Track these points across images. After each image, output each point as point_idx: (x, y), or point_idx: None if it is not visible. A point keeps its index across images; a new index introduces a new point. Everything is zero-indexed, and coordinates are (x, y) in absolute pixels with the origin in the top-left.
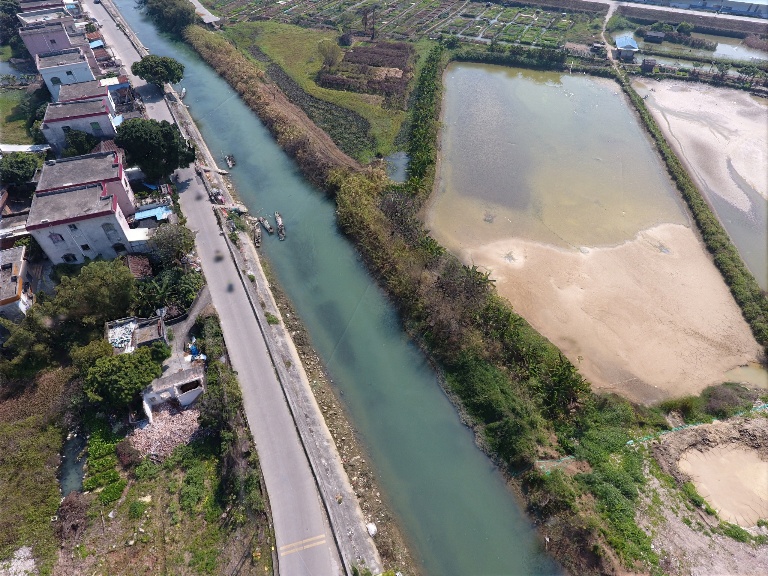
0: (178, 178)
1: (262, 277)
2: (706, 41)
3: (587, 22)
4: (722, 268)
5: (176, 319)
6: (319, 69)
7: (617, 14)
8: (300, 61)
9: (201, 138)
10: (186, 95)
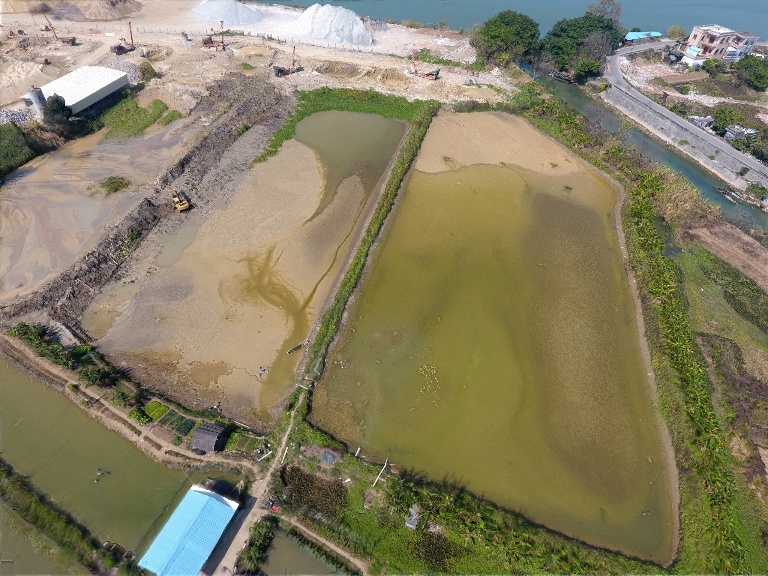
0: None
1: (707, 164)
2: None
3: None
4: None
5: None
6: None
7: None
8: None
9: None
10: None
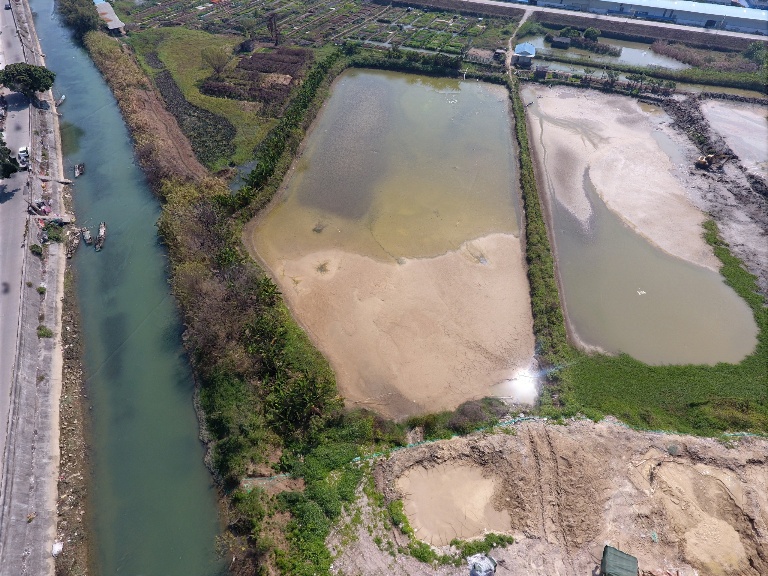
0: (6, 188)
1: (58, 289)
2: (610, 47)
3: (501, 27)
4: (530, 279)
5: None
6: (209, 76)
7: (531, 19)
8: (193, 68)
9: (59, 146)
10: (64, 102)
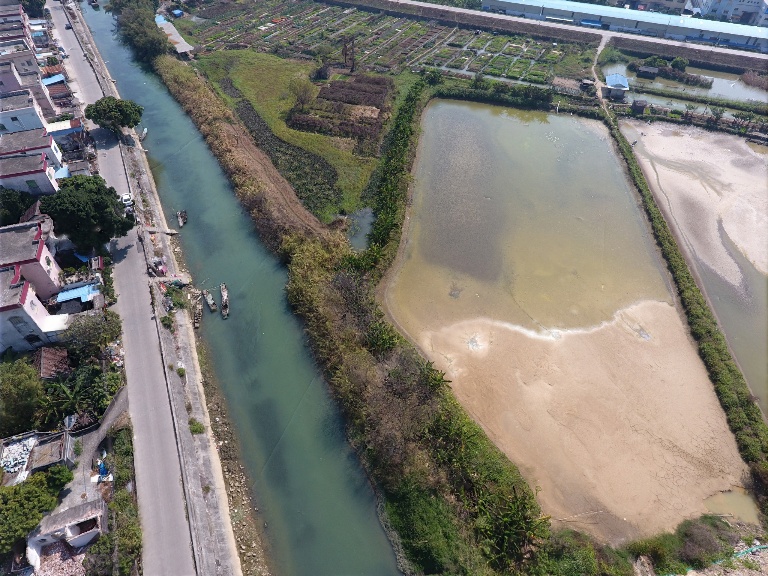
0: (117, 244)
1: (195, 369)
2: (701, 78)
3: (578, 54)
4: (707, 360)
5: (86, 429)
6: (292, 107)
7: (610, 46)
8: (273, 97)
9: (155, 189)
10: (147, 136)
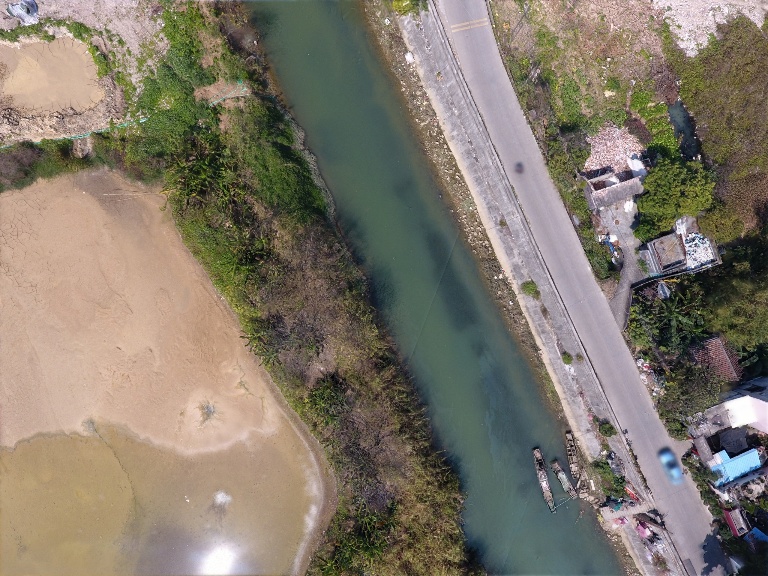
0: None
1: (553, 368)
2: None
3: None
4: None
5: (643, 284)
6: None
7: None
8: None
9: None
10: None
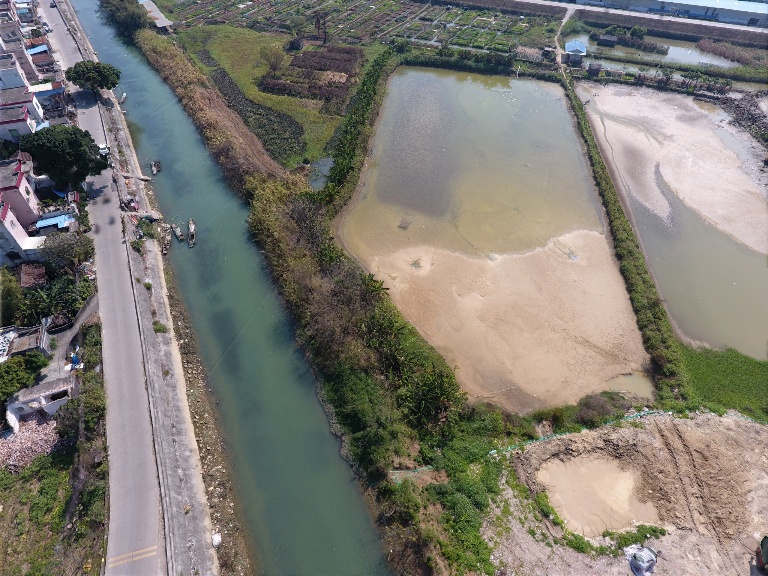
0: (93, 185)
1: (161, 285)
2: (658, 45)
3: (544, 26)
4: (625, 275)
5: (61, 328)
6: (264, 74)
7: (574, 17)
8: (247, 65)
9: (131, 144)
10: (126, 100)
